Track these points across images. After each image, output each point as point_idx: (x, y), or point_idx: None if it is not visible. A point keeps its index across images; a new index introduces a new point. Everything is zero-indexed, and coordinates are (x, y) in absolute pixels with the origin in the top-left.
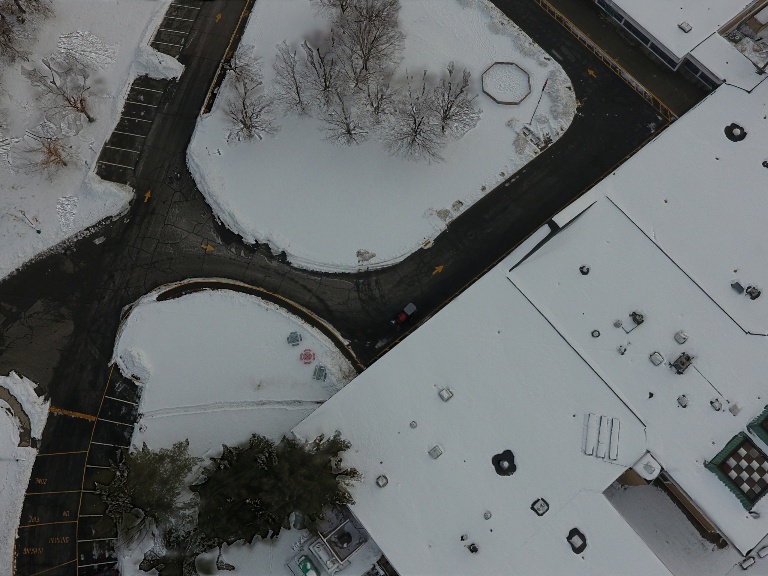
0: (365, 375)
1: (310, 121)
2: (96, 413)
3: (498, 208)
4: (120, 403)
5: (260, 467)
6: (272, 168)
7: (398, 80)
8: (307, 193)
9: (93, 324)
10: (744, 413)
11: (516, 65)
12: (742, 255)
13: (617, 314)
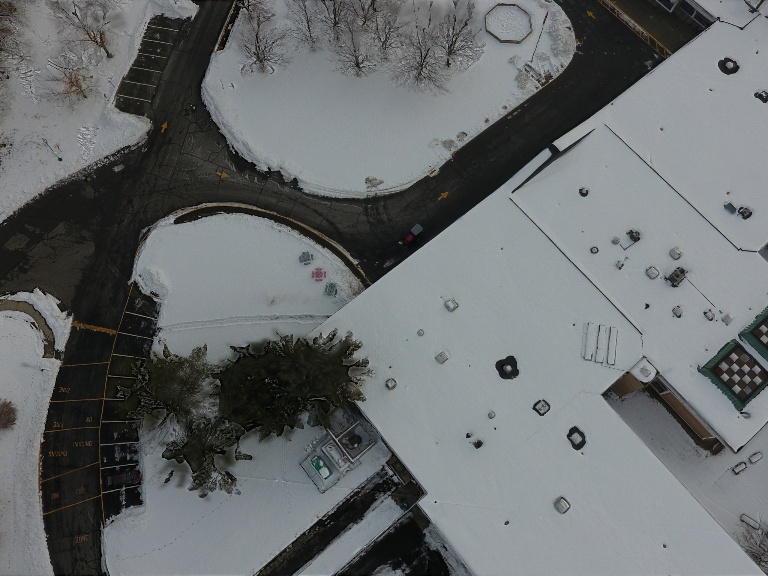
0: (374, 287)
1: (321, 53)
2: (117, 327)
3: (501, 139)
4: (140, 318)
5: (278, 353)
6: (284, 101)
7: (404, 20)
8: (317, 124)
9: (113, 245)
10: (736, 322)
11: (518, 6)
12: (734, 178)
13: (615, 232)
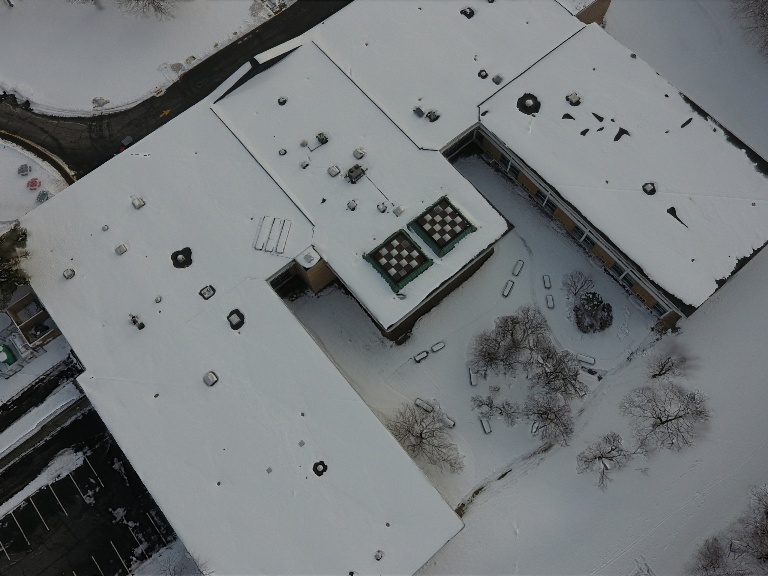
0: (69, 189)
1: None
2: None
3: (228, 62)
4: None
5: None
6: (26, 32)
7: None
8: (56, 52)
9: None
10: (406, 214)
11: None
12: (428, 86)
13: (305, 136)
